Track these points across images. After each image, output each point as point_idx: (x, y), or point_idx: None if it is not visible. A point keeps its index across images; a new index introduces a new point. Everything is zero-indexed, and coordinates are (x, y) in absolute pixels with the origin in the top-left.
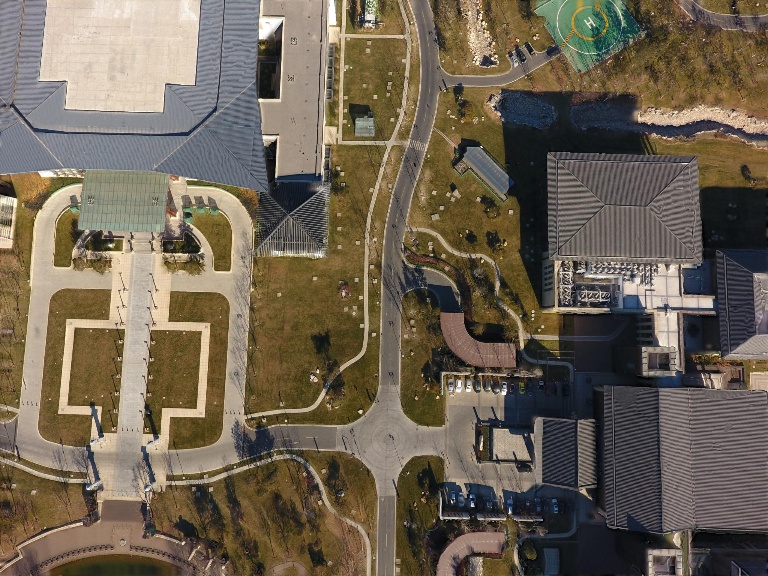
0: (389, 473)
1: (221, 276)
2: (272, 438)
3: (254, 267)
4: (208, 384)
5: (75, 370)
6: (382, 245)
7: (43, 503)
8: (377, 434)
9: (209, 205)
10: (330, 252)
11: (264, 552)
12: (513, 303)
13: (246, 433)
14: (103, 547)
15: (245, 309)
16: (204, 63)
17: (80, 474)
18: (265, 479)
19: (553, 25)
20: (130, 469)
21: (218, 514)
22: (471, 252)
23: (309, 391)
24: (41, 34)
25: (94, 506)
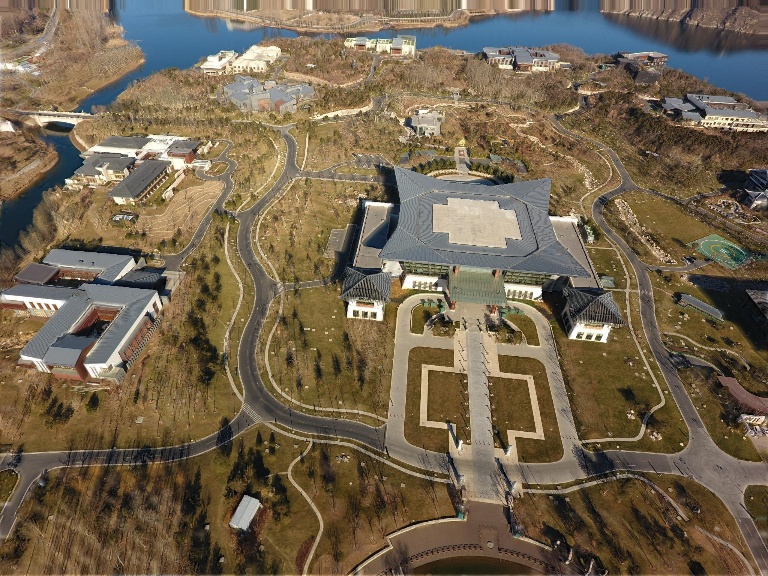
0: (733, 497)
1: (533, 349)
2: (610, 460)
3: (557, 345)
4: (541, 415)
5: (431, 397)
6: (646, 340)
7: (412, 496)
8: (705, 463)
9: (515, 310)
10: (610, 341)
11: (641, 564)
12: (767, 378)
13: (585, 455)
14: (472, 546)
15: (557, 369)
16: (524, 233)
17: (443, 475)
18: (623, 484)
19: (701, 250)
20: (487, 475)
21: (581, 522)
22: (715, 347)
23: (630, 425)
24: (431, 217)
25: (460, 503)
